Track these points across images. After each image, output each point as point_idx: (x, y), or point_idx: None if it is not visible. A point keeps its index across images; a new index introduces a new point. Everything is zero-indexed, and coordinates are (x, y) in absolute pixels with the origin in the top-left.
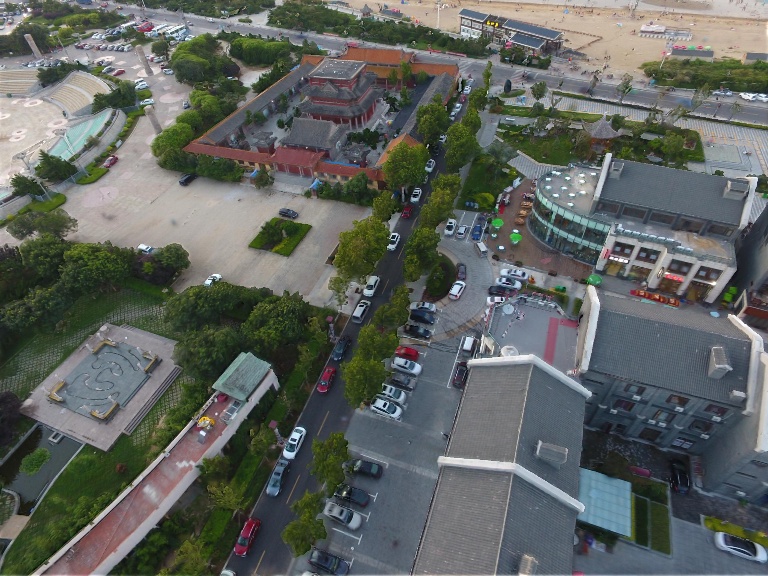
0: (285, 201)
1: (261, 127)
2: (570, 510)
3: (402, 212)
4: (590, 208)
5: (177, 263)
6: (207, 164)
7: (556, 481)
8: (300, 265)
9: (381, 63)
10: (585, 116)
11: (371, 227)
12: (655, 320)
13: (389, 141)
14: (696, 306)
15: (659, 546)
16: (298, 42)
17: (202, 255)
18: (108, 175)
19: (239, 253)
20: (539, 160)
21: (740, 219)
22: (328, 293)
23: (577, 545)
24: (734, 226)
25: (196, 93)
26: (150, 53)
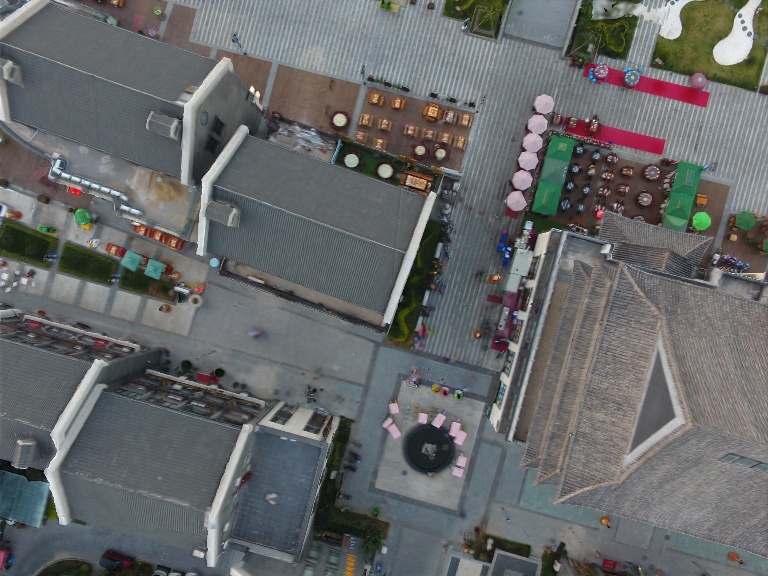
0: None
1: None
2: None
3: None
4: None
5: None
6: None
7: None
8: None
9: None
10: None
11: None
12: None
13: None
14: None
15: (77, 521)
16: None
17: None
18: None
19: None
20: None
21: None
22: None
23: (17, 523)
24: None
25: None
26: None
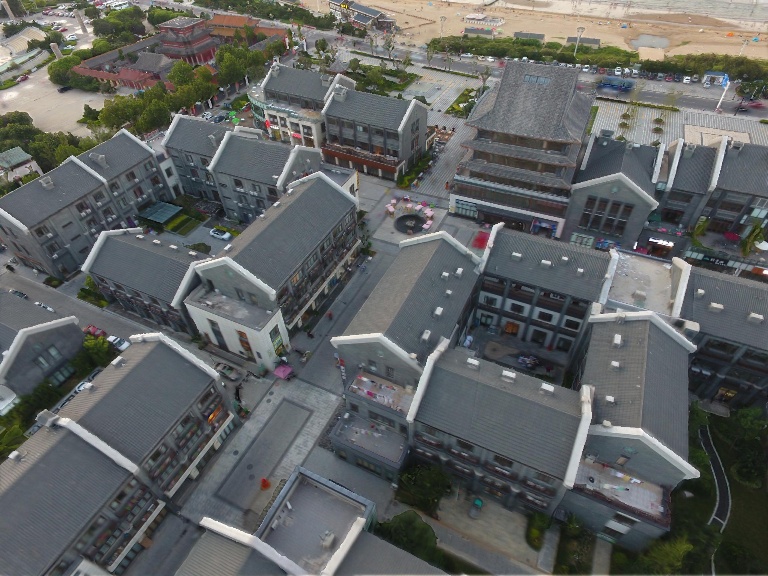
0: None
1: None
2: (98, 181)
3: None
4: (264, 96)
5: (20, 121)
6: (75, 78)
7: (99, 171)
8: None
9: (233, 26)
10: None
11: (128, 100)
12: (201, 122)
13: None
14: None
15: (181, 232)
16: None
17: (47, 125)
18: (17, 86)
19: (70, 125)
20: None
21: None
22: None
23: None
24: (323, 102)
25: (97, 40)
26: (85, 16)
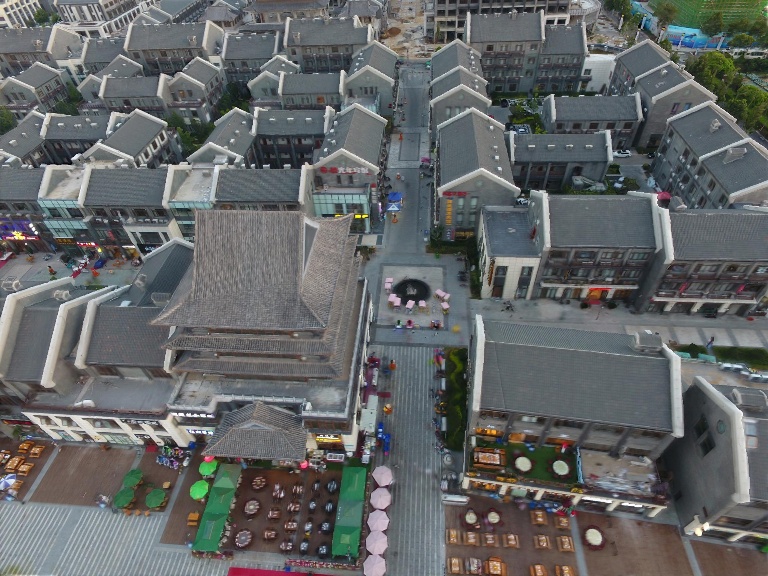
0: None
1: None
2: None
3: None
4: None
5: None
6: None
7: None
8: None
9: None
10: None
11: None
12: None
13: None
14: None
15: None
16: None
17: None
18: None
19: None
20: None
21: None
22: None
23: None
24: None
25: None
26: None
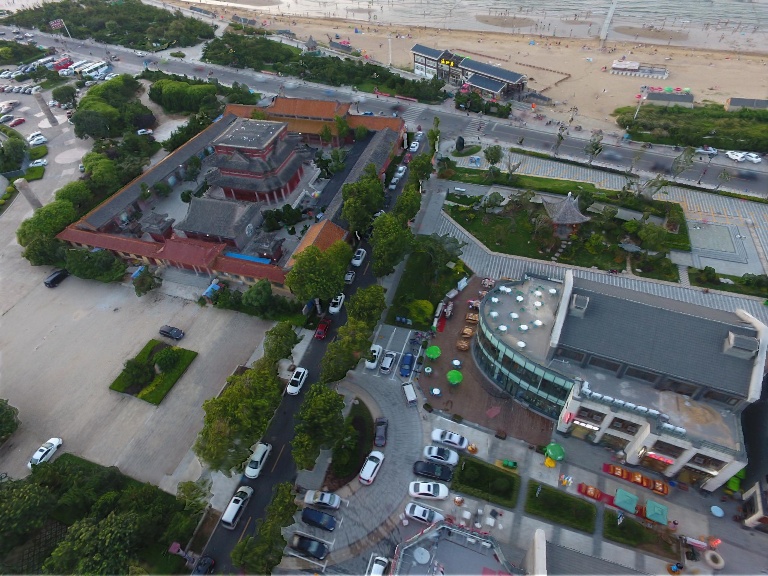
0: (172, 311)
1: (165, 198)
2: None
3: (316, 330)
4: (546, 353)
5: None
6: (77, 262)
7: None
8: (171, 420)
9: (313, 116)
10: (549, 183)
11: (249, 389)
12: None
13: (308, 227)
14: (691, 493)
15: None
16: (231, 82)
17: (46, 402)
18: None
19: (95, 399)
20: (492, 247)
21: (748, 388)
22: (198, 472)
23: None
24: (740, 396)
25: (90, 156)
26: (52, 100)
